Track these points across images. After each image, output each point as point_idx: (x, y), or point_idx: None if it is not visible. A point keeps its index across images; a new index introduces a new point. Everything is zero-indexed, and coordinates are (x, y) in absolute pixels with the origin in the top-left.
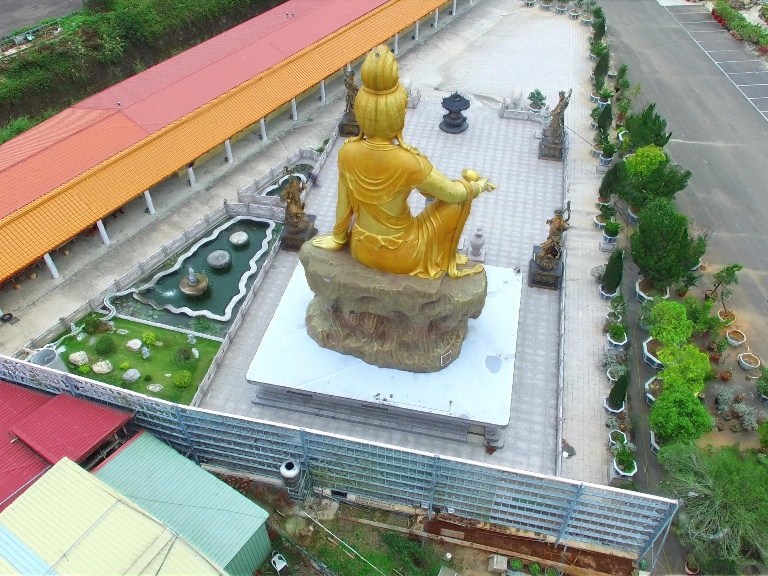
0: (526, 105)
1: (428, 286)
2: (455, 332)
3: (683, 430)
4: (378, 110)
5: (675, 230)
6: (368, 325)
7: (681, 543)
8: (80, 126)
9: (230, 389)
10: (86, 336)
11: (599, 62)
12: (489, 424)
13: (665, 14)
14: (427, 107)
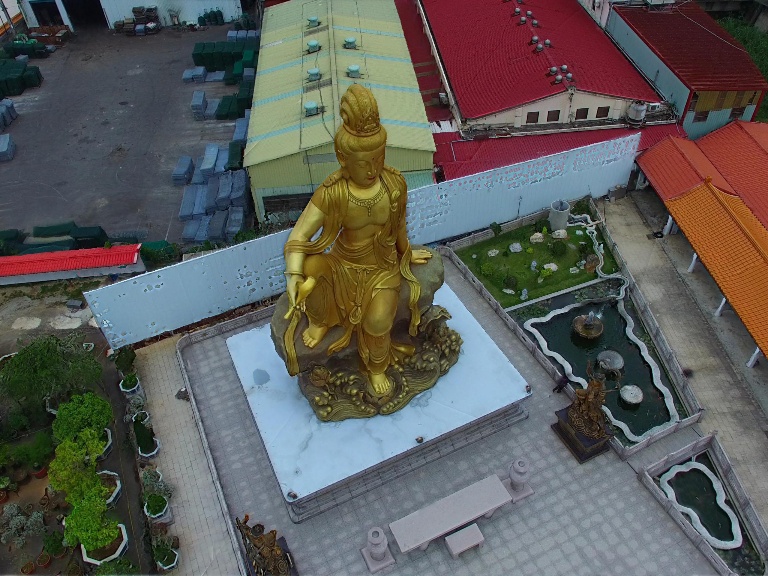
0: None
1: None
2: None
3: None
4: None
5: None
6: None
7: None
8: None
9: (455, 288)
10: None
11: None
12: None
13: None
14: None
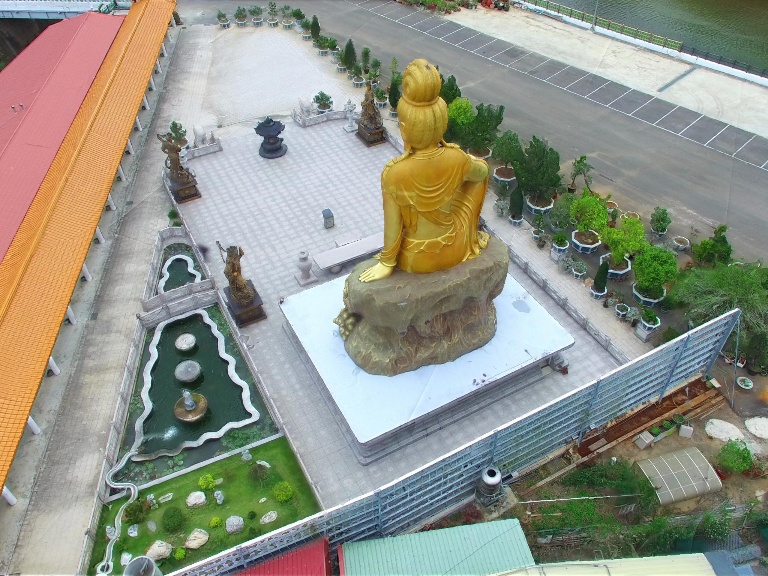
0: (312, 110)
1: (485, 262)
2: None
3: (670, 274)
4: (437, 118)
5: (543, 148)
6: (438, 327)
7: (735, 340)
8: None
9: (332, 470)
10: (139, 527)
11: (346, 52)
12: (564, 348)
13: (340, 1)
14: (231, 145)
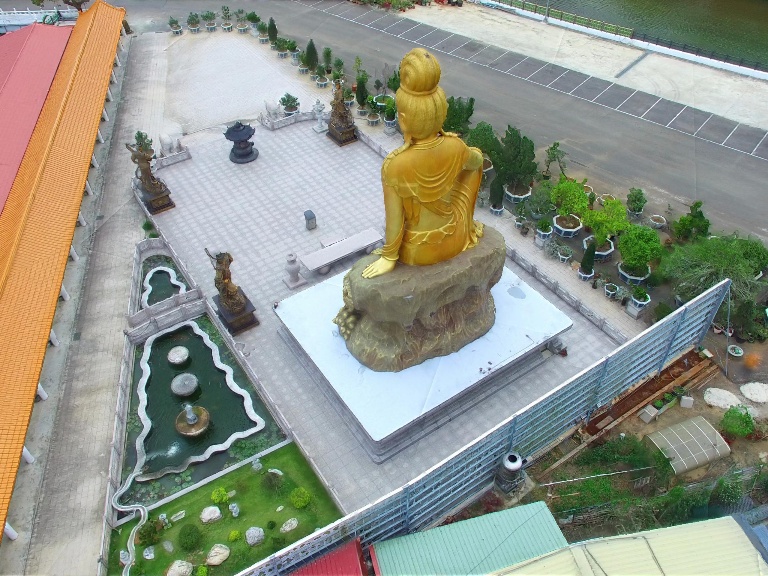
0: None
1: (484, 250)
2: None
3: (655, 251)
4: (437, 107)
5: (518, 137)
6: (442, 319)
7: (724, 310)
8: None
9: (346, 472)
10: (154, 549)
11: (308, 53)
12: (564, 331)
13: (292, 3)
14: (199, 152)
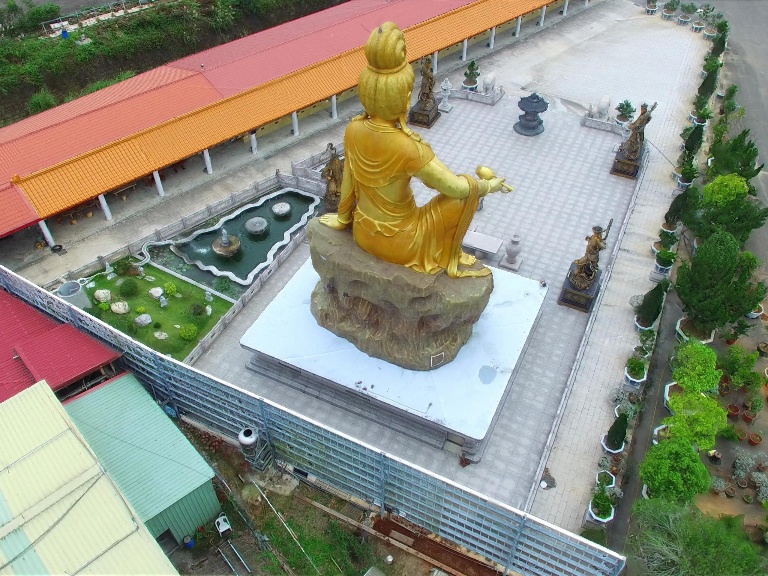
0: (614, 116)
1: (420, 280)
2: (452, 334)
3: (672, 485)
4: (377, 89)
5: (728, 269)
6: (361, 311)
7: None
8: (163, 82)
9: (230, 350)
10: (115, 276)
11: (705, 79)
12: (463, 435)
13: None
14: (507, 105)
